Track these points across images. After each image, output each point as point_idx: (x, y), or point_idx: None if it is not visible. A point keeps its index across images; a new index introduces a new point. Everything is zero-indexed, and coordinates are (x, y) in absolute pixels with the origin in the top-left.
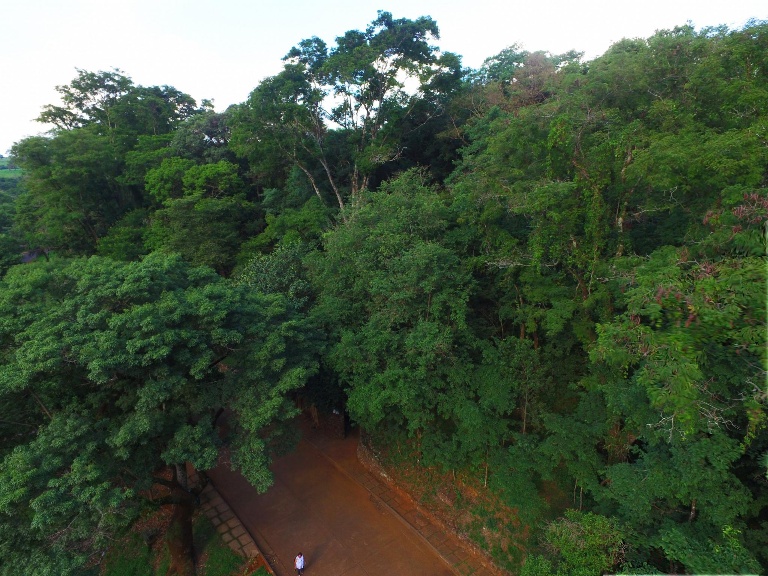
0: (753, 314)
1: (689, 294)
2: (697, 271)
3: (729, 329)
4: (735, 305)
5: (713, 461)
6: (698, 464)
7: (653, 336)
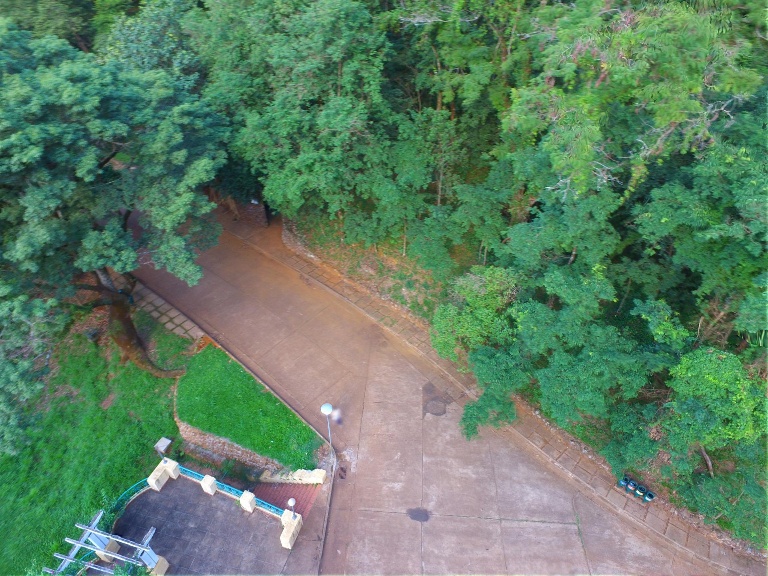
0: (659, 70)
1: (605, 50)
2: (617, 22)
3: (634, 87)
4: (645, 61)
5: (596, 214)
6: (583, 218)
7: (564, 99)
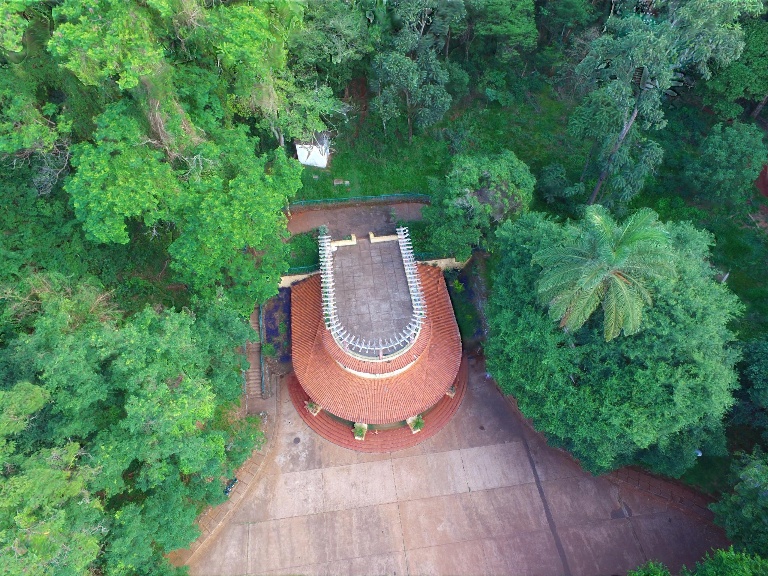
0: None
1: None
2: None
3: None
4: None
5: None
6: (87, 527)
7: (42, 555)
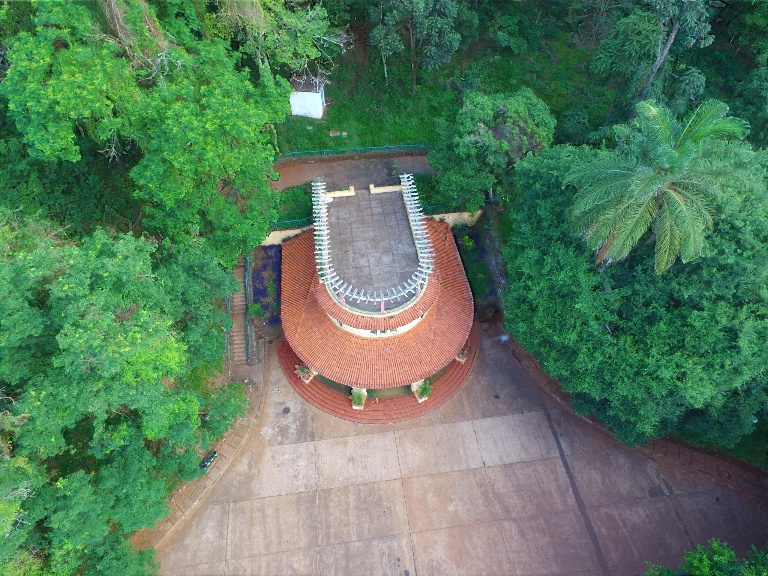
0: None
1: None
2: None
3: None
4: None
5: None
6: None
7: None
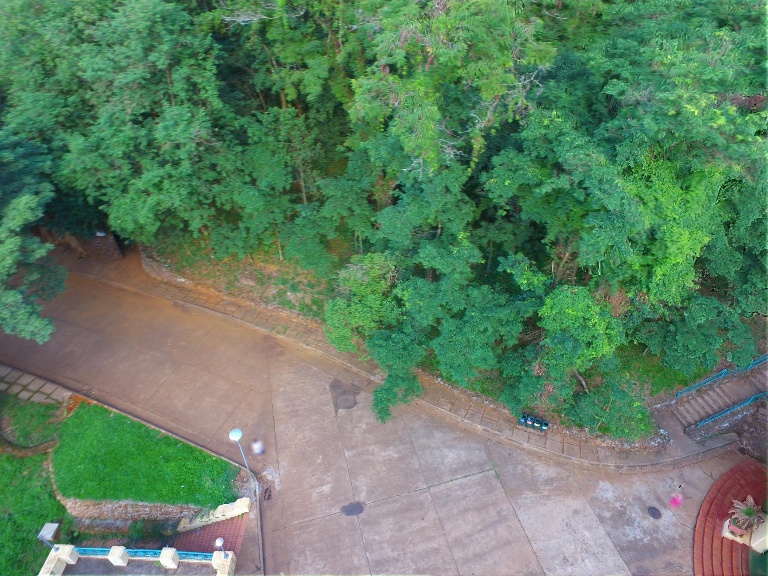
0: (476, 50)
1: (427, 35)
2: (432, 9)
3: (459, 67)
4: None
5: (451, 187)
6: (441, 192)
7: (401, 85)
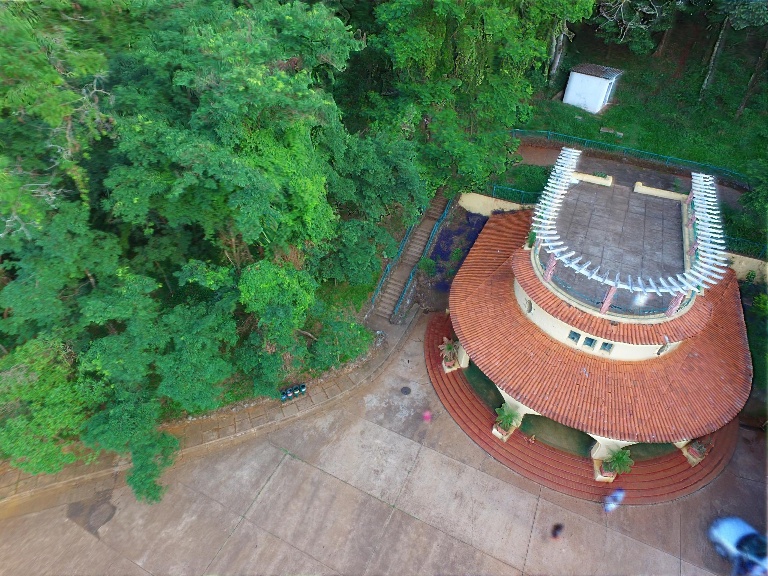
0: (5, 73)
1: None
2: None
3: None
4: None
5: (75, 230)
6: (67, 240)
7: None
